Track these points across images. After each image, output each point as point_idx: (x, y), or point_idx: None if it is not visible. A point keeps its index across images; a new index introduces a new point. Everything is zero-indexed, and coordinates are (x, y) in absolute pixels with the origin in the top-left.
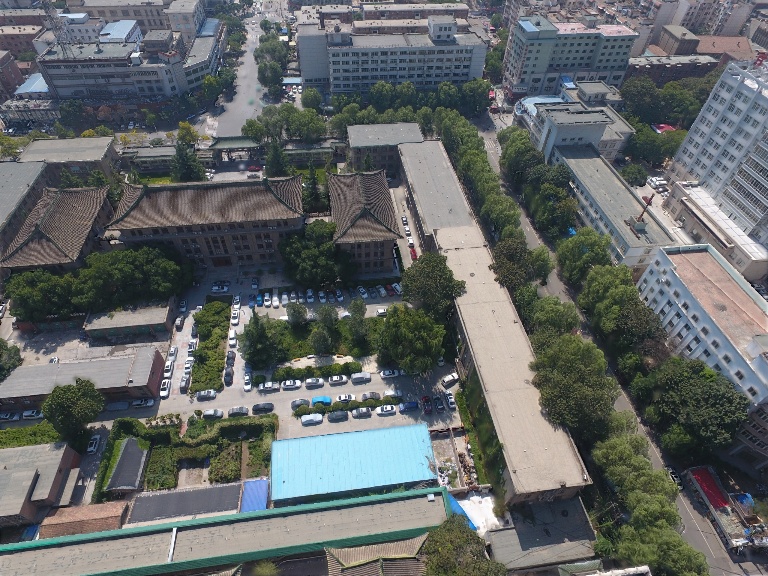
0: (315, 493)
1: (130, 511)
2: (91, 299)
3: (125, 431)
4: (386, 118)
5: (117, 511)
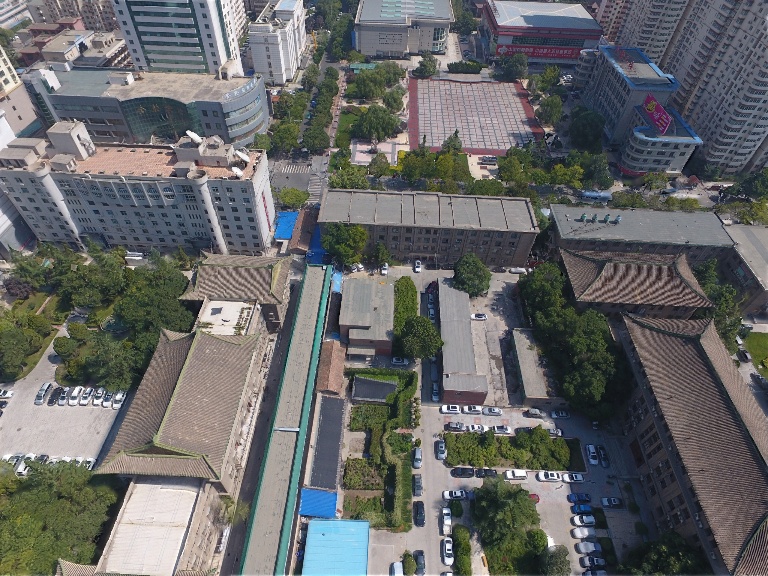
0: (303, 572)
1: (333, 396)
2: (543, 326)
3: (408, 382)
4: None
5: (332, 386)
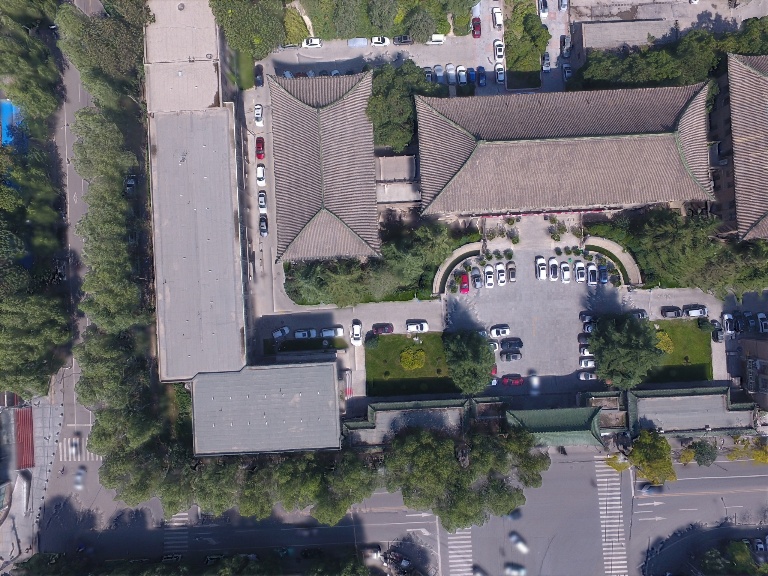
0: None
1: None
2: None
3: None
4: (258, 484)
5: None
